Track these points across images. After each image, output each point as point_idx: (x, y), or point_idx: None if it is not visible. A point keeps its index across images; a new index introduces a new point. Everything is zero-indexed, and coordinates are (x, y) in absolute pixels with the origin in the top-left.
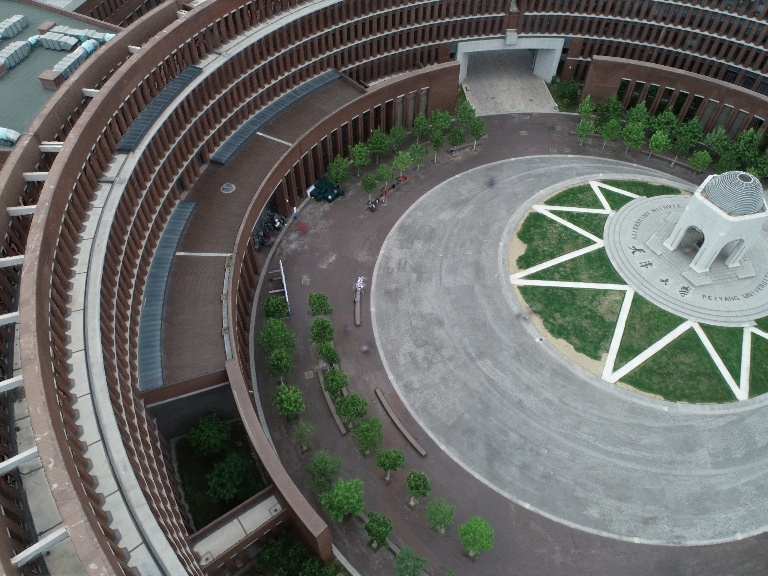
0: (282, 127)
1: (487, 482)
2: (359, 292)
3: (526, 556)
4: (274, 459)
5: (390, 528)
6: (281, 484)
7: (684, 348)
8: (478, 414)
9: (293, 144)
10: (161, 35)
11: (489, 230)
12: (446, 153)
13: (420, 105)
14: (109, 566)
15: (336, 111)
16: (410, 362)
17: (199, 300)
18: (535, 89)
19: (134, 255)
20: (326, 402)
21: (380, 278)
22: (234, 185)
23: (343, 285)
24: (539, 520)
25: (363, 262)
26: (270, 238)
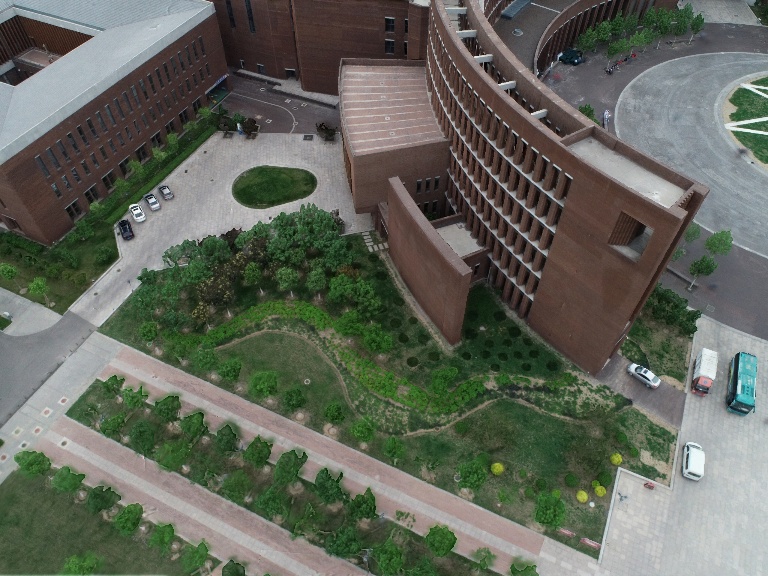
0: (550, 1)
1: None
2: (606, 119)
3: (748, 273)
4: None
5: None
6: None
7: None
8: None
9: (564, 9)
10: None
11: (705, 95)
12: (666, 44)
13: (648, 5)
14: None
15: None
16: None
17: None
18: (739, 8)
19: None
20: None
21: (621, 114)
22: (522, 31)
23: None
24: (756, 257)
25: (606, 104)
26: None
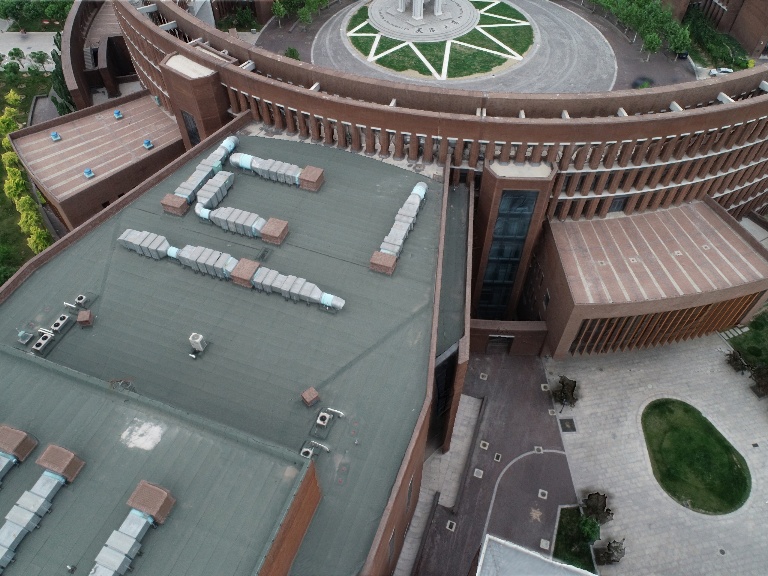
0: None
1: None
2: None
3: None
4: None
5: None
6: None
7: (497, 32)
8: None
9: None
10: (308, 66)
11: None
12: None
13: None
14: None
15: None
16: None
17: None
18: None
19: None
20: None
21: None
22: None
23: None
24: None
25: None
26: None
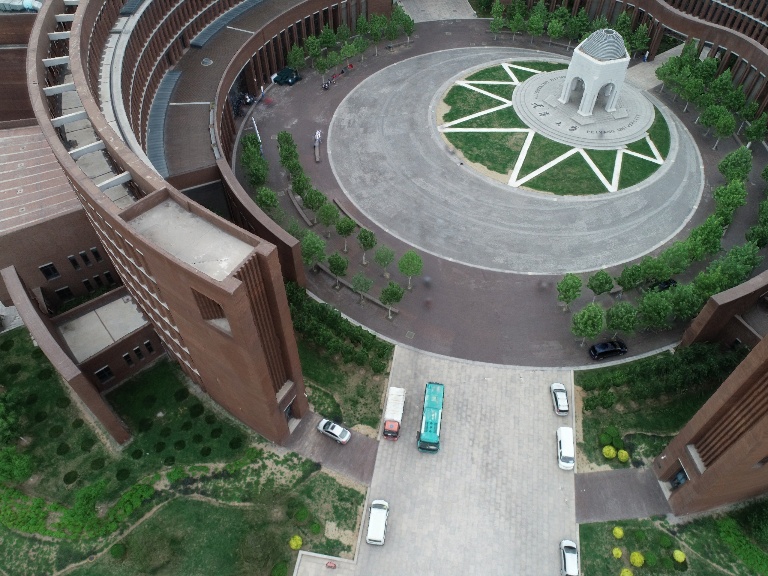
0: (247, 22)
1: (420, 248)
2: (318, 141)
3: (449, 286)
4: (258, 210)
5: (347, 261)
6: (264, 222)
7: (571, 164)
8: (413, 210)
9: (257, 30)
10: None
11: (421, 98)
12: (385, 49)
13: (361, 12)
14: (159, 176)
15: (291, 8)
16: (360, 182)
17: (191, 130)
18: (458, 3)
19: (139, 94)
20: (296, 209)
21: (334, 132)
22: (211, 60)
23: (305, 138)
24: (459, 267)
25: (320, 123)
26: (243, 110)
